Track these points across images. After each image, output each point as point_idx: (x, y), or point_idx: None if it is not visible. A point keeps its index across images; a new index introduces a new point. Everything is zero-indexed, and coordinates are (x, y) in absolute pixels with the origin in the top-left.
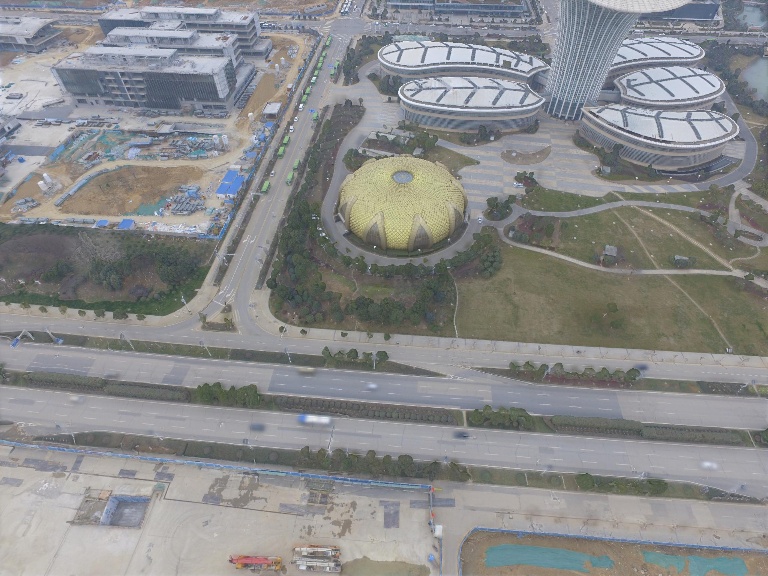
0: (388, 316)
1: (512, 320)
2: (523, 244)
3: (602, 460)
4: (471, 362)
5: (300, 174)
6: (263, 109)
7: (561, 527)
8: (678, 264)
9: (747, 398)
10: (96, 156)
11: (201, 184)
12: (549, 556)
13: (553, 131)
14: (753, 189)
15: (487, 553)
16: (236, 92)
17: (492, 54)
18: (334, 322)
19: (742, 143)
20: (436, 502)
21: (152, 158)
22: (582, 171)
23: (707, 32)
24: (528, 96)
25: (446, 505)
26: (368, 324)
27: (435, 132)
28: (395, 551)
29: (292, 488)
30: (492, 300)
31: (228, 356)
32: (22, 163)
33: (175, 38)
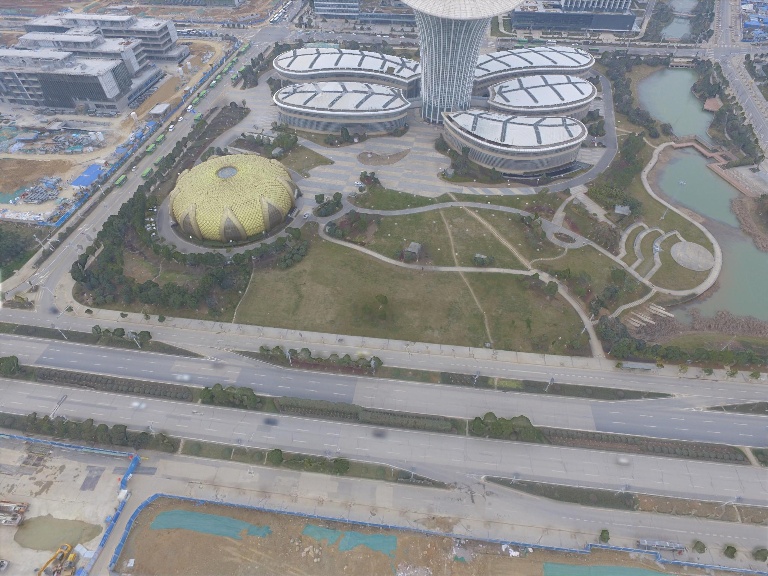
0: (167, 300)
1: (291, 309)
2: (337, 239)
3: (312, 440)
4: (234, 345)
5: None
6: (150, 109)
7: (242, 498)
8: (475, 262)
9: (483, 390)
10: None
11: (64, 176)
12: (210, 522)
13: (420, 135)
14: (588, 193)
15: (157, 517)
16: (131, 93)
17: (379, 61)
18: (124, 304)
19: (602, 150)
20: (138, 470)
21: (32, 152)
22: (429, 173)
23: (620, 43)
24: (395, 100)
25: (146, 473)
26: (155, 307)
27: (304, 133)
28: (79, 511)
29: (14, 450)
30: (281, 289)
31: (13, 331)
32: None
33: (78, 42)
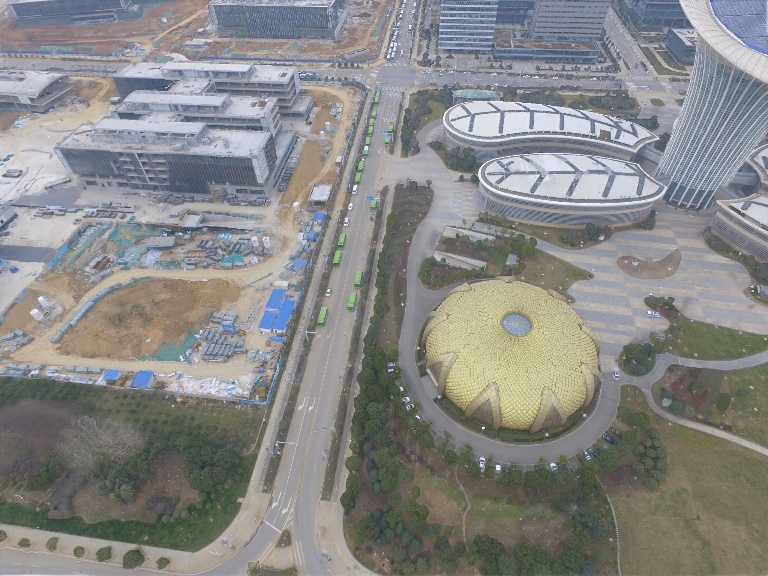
0: (528, 575)
1: (706, 571)
2: (685, 419)
3: None
4: None
5: (364, 293)
6: (310, 194)
7: None
8: None
9: None
10: (106, 263)
11: (238, 309)
12: None
13: (675, 225)
14: None
15: None
16: (276, 170)
17: (585, 121)
18: (443, 572)
19: None
20: None
21: (176, 266)
22: (731, 290)
23: None
24: (645, 183)
25: None
26: None
27: (527, 227)
28: None
29: None
30: (668, 530)
31: None
32: (14, 273)
33: (203, 106)
